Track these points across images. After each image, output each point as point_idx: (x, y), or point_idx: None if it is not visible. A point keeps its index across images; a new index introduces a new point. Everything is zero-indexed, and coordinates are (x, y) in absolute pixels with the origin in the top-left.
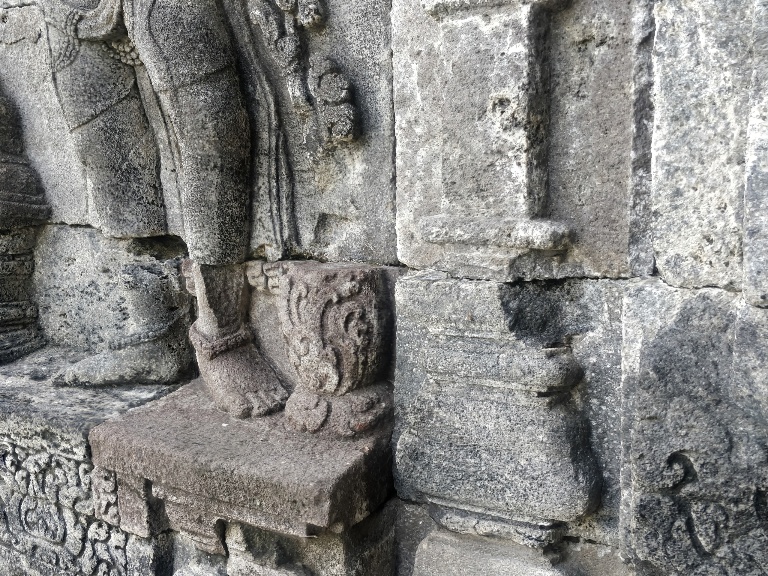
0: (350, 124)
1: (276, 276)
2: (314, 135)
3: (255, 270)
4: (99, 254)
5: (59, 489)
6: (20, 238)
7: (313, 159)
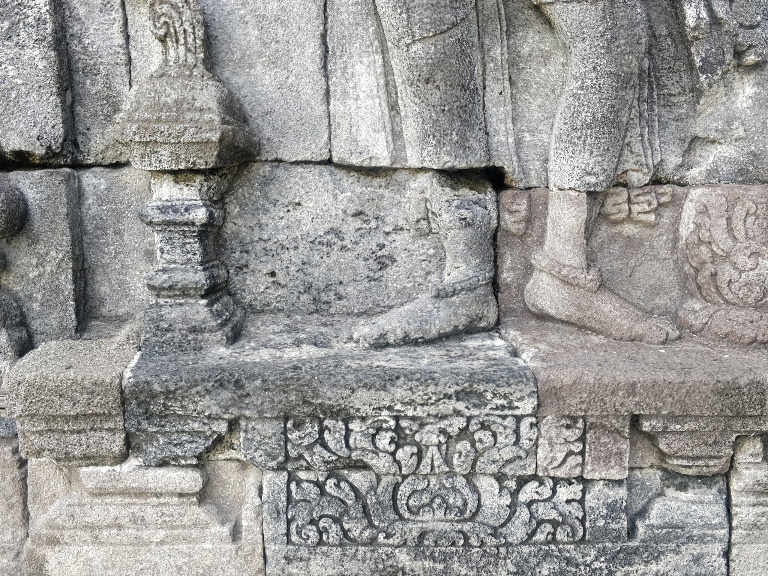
0: (767, 48)
1: (646, 201)
2: (714, 58)
3: (618, 197)
4: (348, 194)
5: (476, 455)
6: (225, 179)
7: (709, 82)
